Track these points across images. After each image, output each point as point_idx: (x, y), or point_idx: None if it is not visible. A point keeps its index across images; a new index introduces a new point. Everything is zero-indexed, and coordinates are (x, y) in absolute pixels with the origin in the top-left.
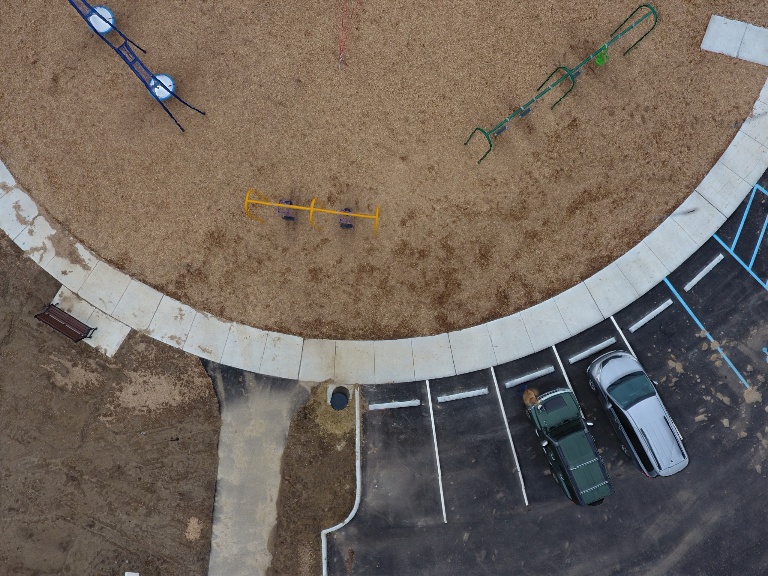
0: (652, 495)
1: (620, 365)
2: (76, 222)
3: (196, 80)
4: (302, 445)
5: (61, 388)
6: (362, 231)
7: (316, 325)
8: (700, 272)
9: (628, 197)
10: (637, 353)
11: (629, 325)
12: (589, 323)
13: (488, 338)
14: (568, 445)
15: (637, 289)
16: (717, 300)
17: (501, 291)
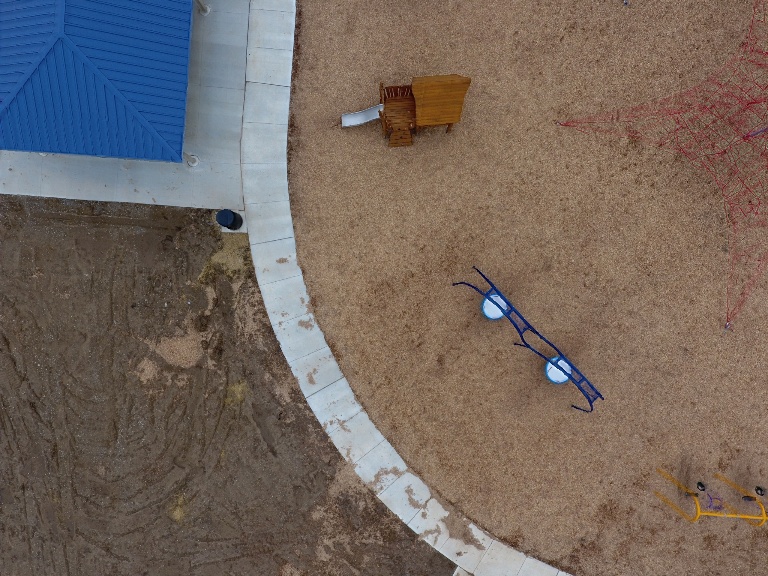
0: None
1: None
2: (469, 503)
3: (581, 354)
4: None
5: None
6: None
7: None
8: None
9: None
10: None
11: None
12: None
13: None
14: None
15: None
16: None
17: None
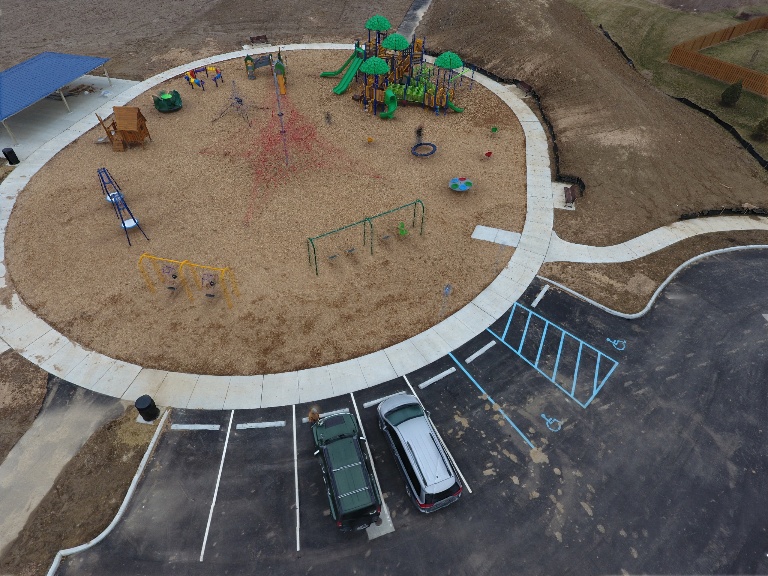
0: (440, 554)
1: (399, 398)
2: (25, 283)
3: (153, 226)
4: (92, 454)
5: None
6: (222, 304)
7: (158, 359)
8: (477, 351)
9: (421, 302)
10: (426, 406)
11: (419, 383)
12: (385, 379)
13: (296, 382)
14: (335, 448)
15: (426, 358)
16: (494, 372)
17: (315, 350)
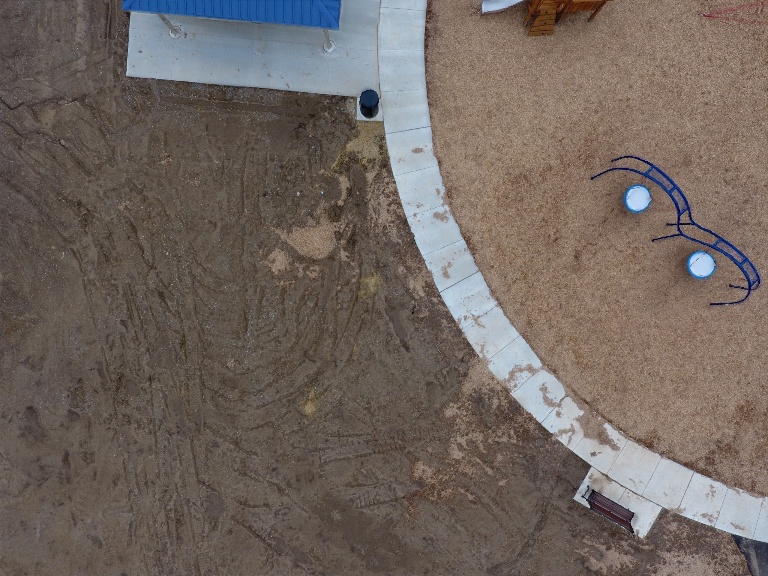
0: None
1: None
2: (604, 402)
3: None
4: None
5: (596, 572)
6: None
7: None
8: None
9: None
10: None
11: None
12: None
13: None
14: None
15: None
16: None
17: None
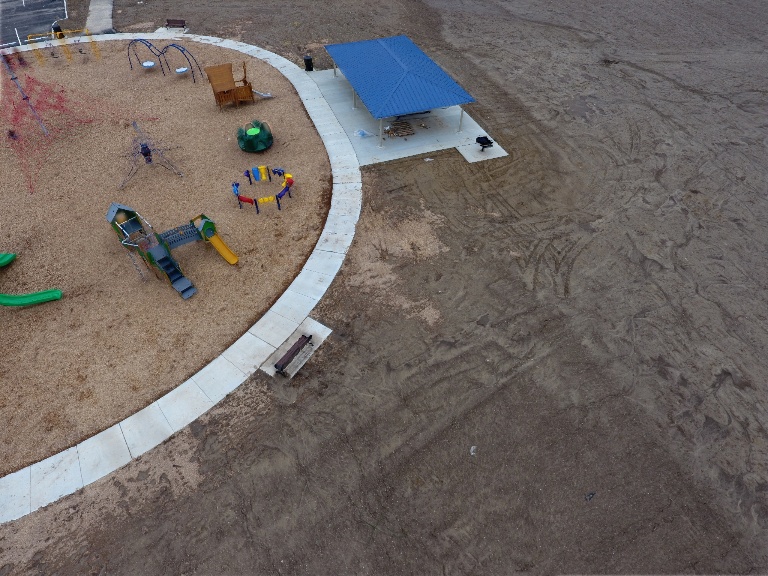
0: None
1: None
2: None
3: None
4: None
5: None
6: None
7: None
8: None
9: None
10: None
11: None
12: None
13: None
14: None
15: None
16: None
17: None
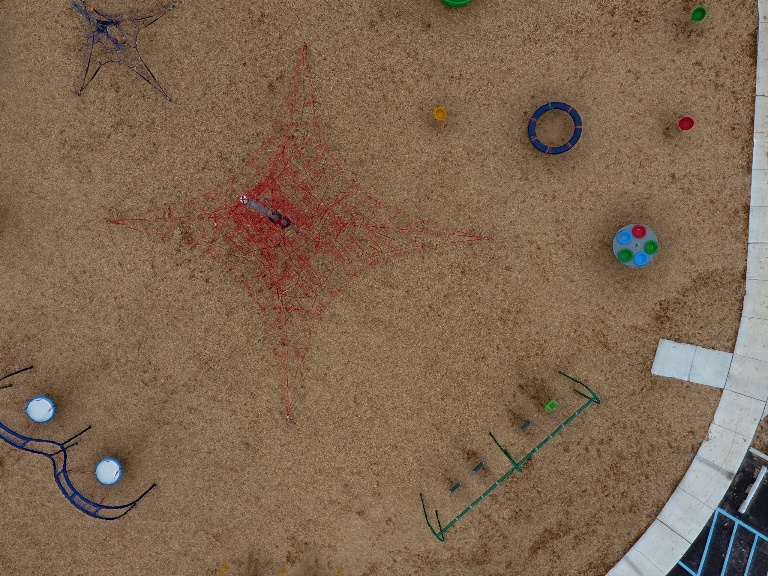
0: None
1: None
2: None
3: (144, 451)
4: None
5: None
6: None
7: None
8: None
9: (589, 531)
10: None
11: None
12: None
13: None
14: None
15: None
16: None
17: None
